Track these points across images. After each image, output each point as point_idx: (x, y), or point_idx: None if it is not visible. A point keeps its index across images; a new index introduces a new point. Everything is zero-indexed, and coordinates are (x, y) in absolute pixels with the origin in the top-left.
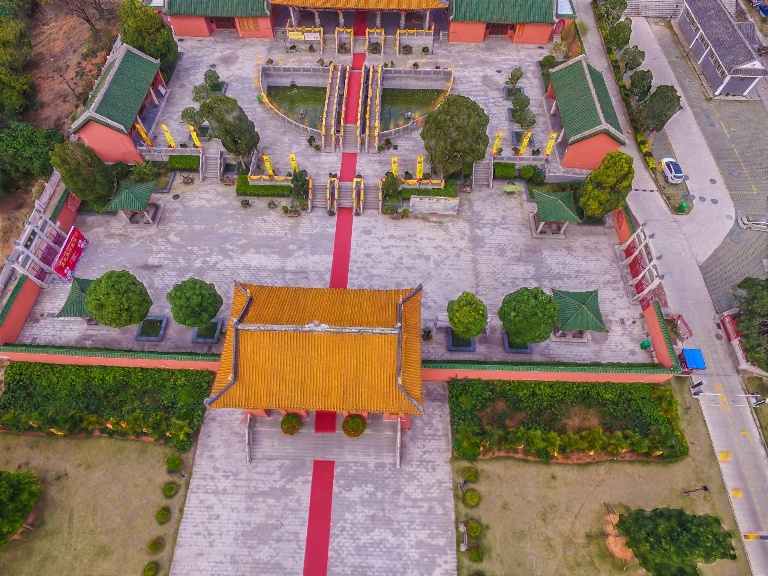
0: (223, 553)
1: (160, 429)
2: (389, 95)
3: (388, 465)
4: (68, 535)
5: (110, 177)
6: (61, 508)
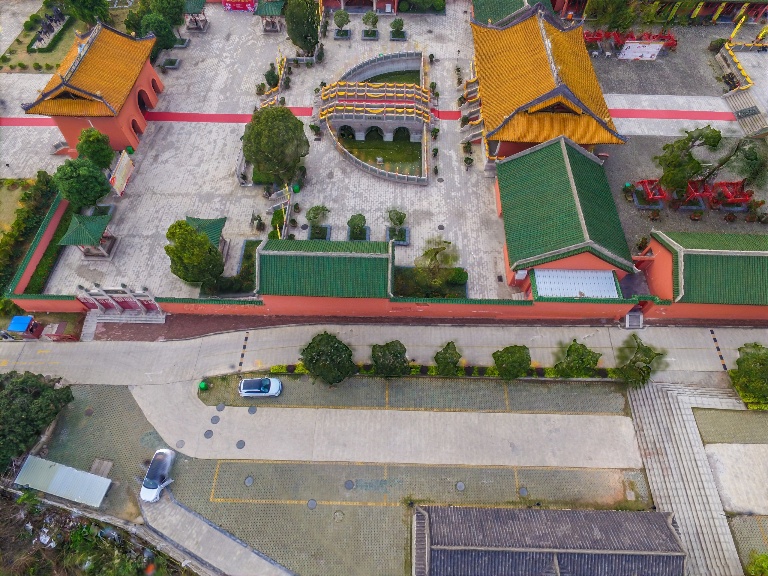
0: None
1: None
2: (413, 148)
3: None
4: None
5: None
6: None
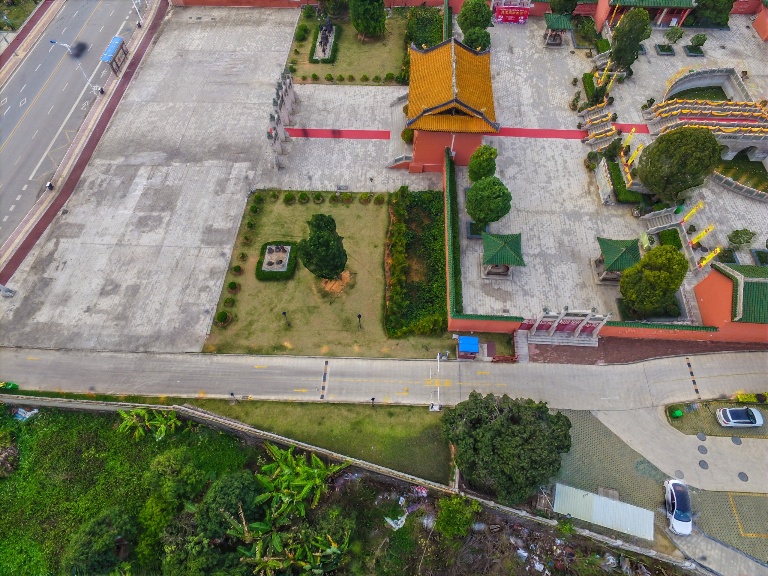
0: (345, 101)
1: (407, 64)
2: (754, 168)
3: (387, 162)
4: (358, 52)
5: (569, 7)
6: (371, 48)
